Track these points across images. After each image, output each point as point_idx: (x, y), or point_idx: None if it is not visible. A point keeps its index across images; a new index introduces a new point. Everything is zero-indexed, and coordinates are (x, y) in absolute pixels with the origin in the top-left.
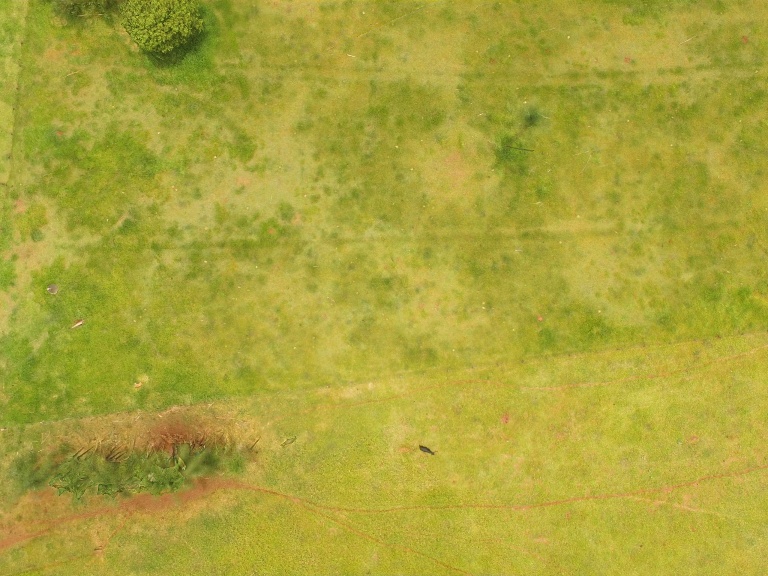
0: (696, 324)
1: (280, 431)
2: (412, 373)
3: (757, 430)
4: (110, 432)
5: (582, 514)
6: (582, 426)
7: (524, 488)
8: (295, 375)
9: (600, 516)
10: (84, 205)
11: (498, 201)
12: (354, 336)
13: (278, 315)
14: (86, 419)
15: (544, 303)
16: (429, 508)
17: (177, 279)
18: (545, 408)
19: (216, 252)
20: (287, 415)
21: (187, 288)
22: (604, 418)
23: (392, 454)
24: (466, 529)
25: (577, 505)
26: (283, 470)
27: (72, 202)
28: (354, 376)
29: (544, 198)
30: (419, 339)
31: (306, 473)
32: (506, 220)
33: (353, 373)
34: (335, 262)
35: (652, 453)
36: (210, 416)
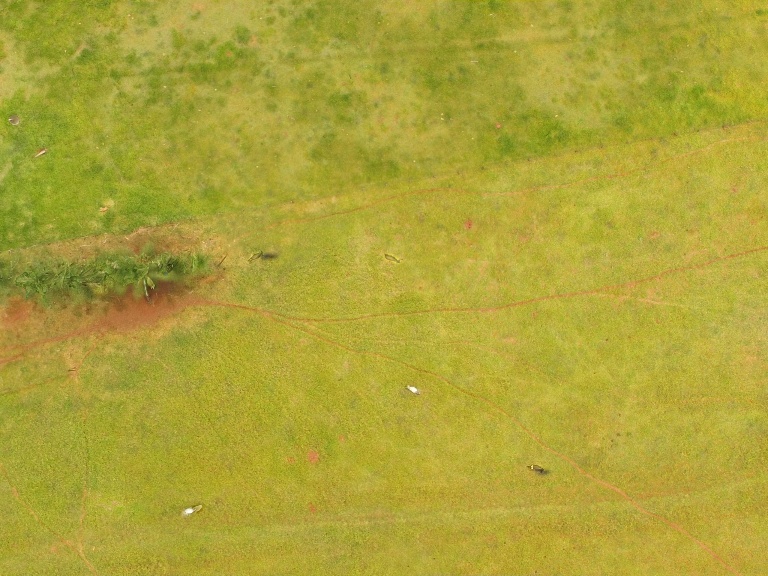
0: (652, 123)
1: (246, 247)
2: (374, 185)
3: (716, 222)
4: (78, 256)
5: (548, 312)
6: (544, 228)
7: (490, 290)
8: (259, 192)
9: (565, 313)
10: (41, 37)
11: (452, 14)
12: (315, 152)
13: (239, 135)
14: (54, 245)
15: (502, 111)
16: (397, 314)
17: (137, 105)
18: (507, 212)
19: (175, 77)
20: (253, 231)
21: (148, 113)
22: (565, 218)
23: (358, 264)
24: (434, 332)
25: (542, 304)
26: (251, 284)
27: (29, 34)
28: (317, 191)
29: (497, 9)
30: (380, 152)
31: (274, 286)
32: (461, 32)
33: (316, 188)
34: (293, 81)
35: (614, 250)
36: (176, 236)
